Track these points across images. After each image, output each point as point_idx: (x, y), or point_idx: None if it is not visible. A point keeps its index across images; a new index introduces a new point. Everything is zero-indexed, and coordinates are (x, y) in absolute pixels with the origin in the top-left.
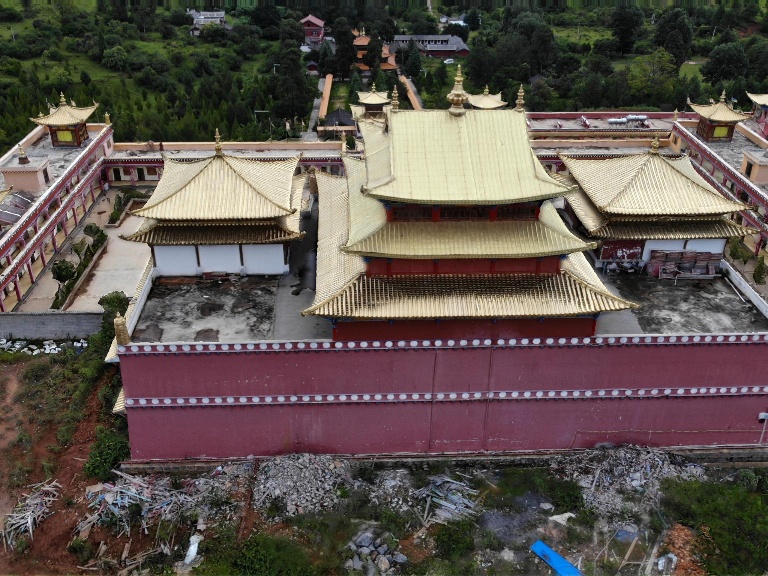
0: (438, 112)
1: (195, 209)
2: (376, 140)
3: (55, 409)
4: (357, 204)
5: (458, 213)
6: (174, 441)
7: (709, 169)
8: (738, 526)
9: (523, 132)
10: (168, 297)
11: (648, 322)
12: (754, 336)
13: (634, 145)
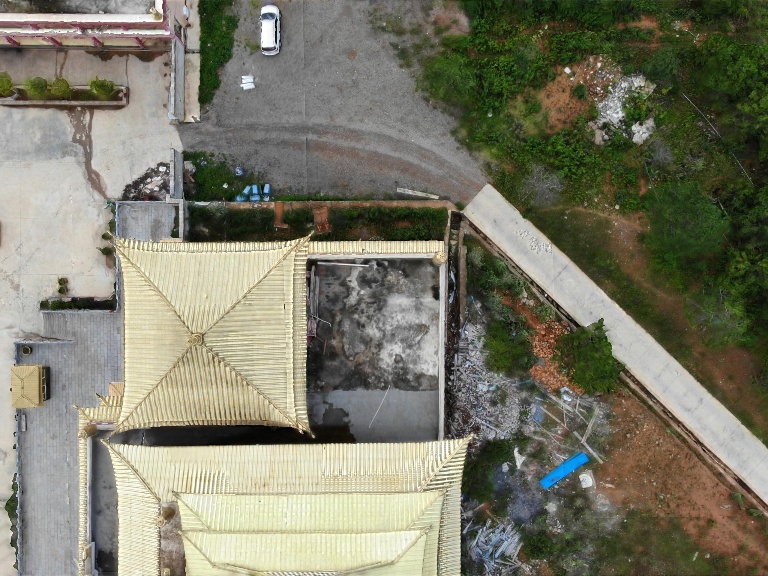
0: None
1: None
2: None
3: None
4: None
5: None
6: None
7: None
8: None
9: None
10: None
11: (403, 381)
12: None
13: None
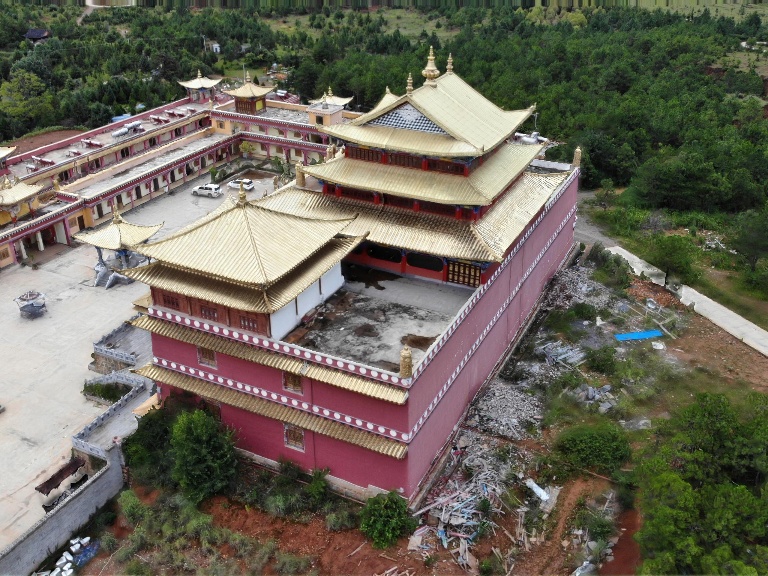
0: (425, 88)
1: (289, 255)
2: (365, 133)
3: (235, 567)
4: (399, 186)
5: (486, 154)
6: (426, 454)
7: (275, 135)
8: (679, 254)
9: (467, 87)
10: (322, 348)
11: None
12: (573, 175)
13: (194, 139)
